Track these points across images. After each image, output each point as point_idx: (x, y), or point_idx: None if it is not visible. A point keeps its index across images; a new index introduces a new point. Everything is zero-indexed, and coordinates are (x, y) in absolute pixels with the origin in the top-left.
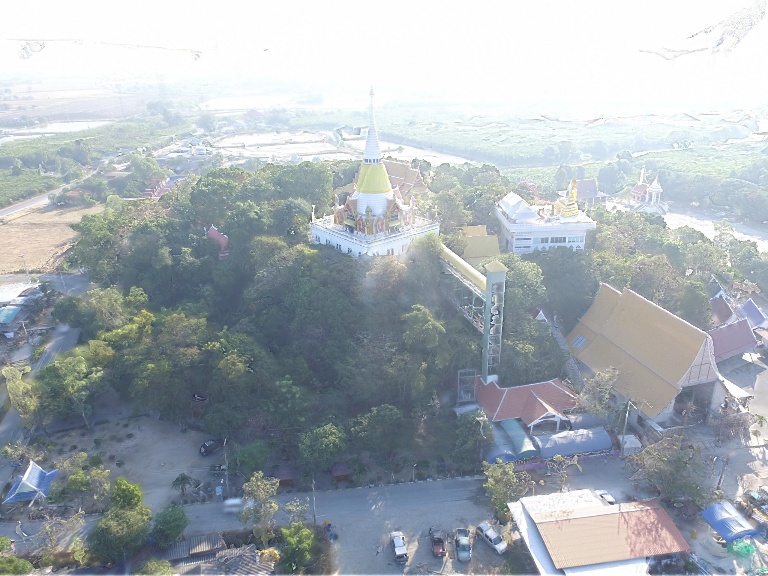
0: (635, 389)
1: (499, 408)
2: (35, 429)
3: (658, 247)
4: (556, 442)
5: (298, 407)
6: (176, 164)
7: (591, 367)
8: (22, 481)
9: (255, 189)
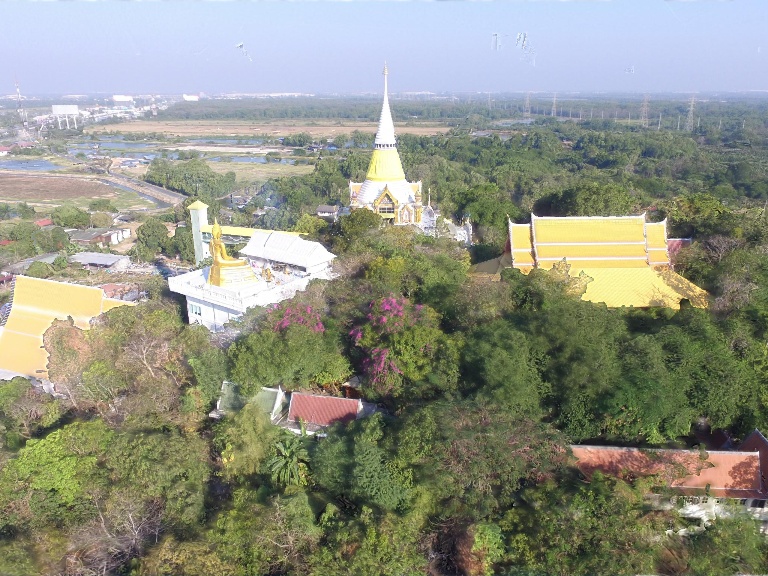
0: None
1: None
2: None
3: None
4: None
5: None
6: None
7: None
8: None
9: None
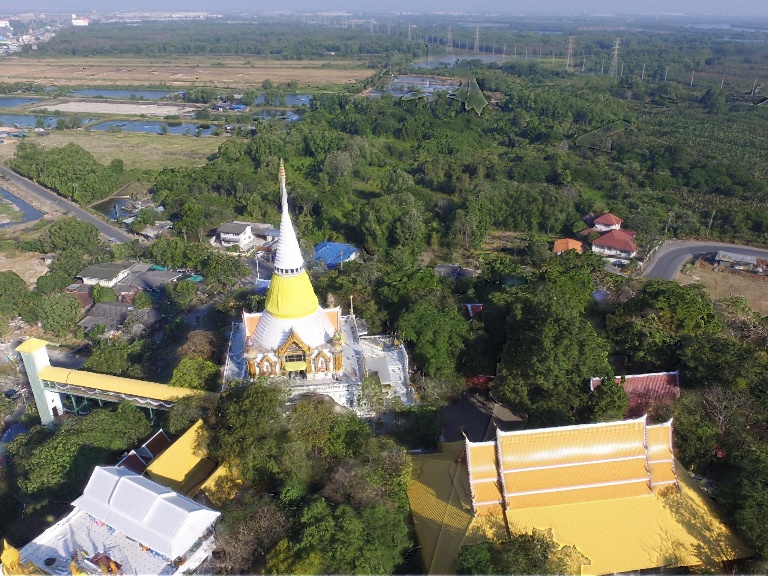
0: None
1: None
2: None
3: None
4: None
5: None
6: None
7: None
8: None
9: None
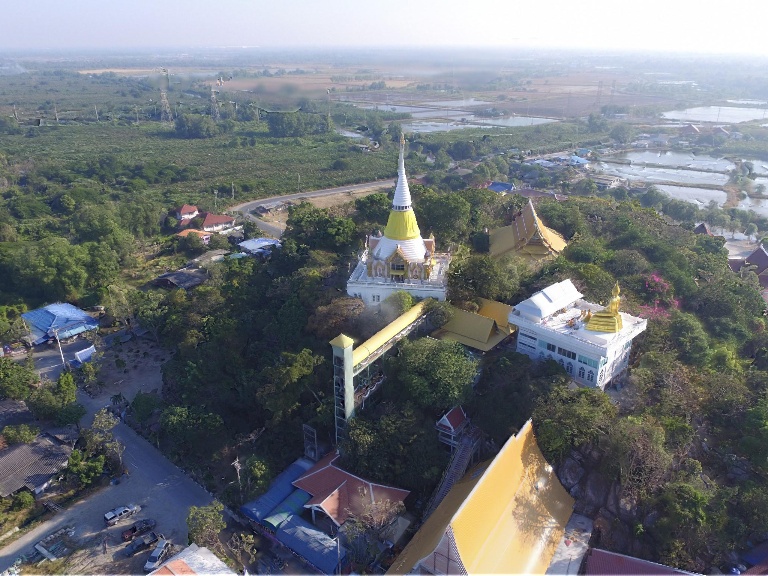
0: (418, 544)
1: (307, 476)
2: (146, 332)
3: (758, 427)
4: (295, 533)
5: (189, 386)
6: (528, 171)
7: (442, 501)
8: (76, 353)
9: (385, 209)
